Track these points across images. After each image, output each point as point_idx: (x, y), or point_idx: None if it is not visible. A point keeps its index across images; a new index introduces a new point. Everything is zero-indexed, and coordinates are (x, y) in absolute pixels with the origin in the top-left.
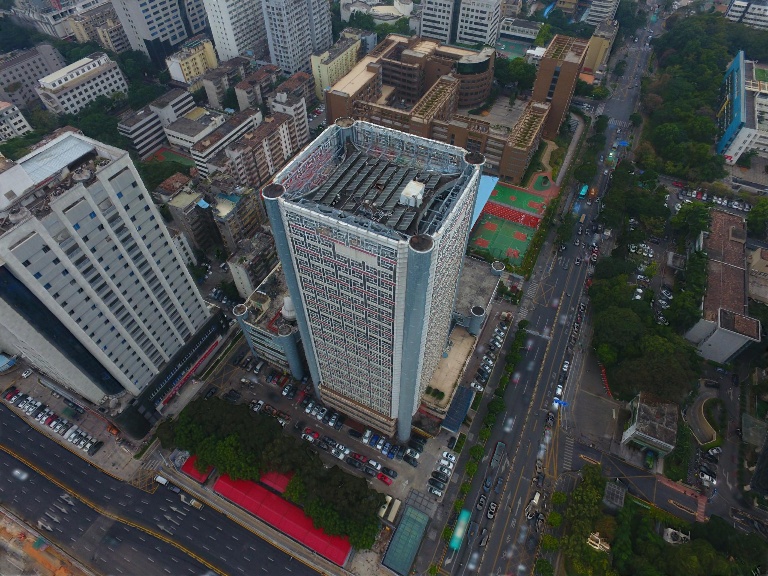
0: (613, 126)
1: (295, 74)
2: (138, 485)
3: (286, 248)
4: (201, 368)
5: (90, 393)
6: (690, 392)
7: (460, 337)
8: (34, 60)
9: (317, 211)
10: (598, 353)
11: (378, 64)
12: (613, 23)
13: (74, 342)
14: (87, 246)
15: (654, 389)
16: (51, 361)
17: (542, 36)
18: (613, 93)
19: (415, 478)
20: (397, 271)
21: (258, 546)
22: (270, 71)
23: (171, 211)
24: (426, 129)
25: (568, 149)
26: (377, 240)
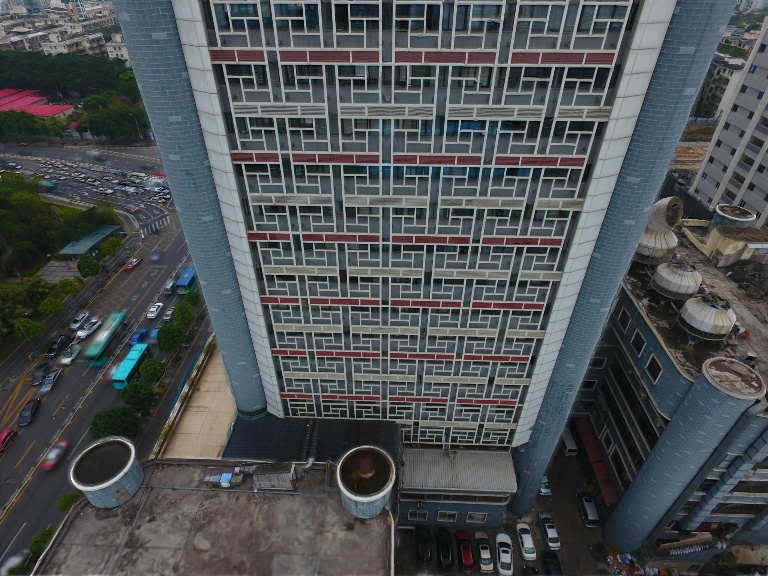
0: None
1: None
2: None
3: None
4: None
5: None
6: None
7: None
8: None
9: None
10: None
11: None
12: None
13: None
14: None
15: None
16: None
17: None
18: None
19: None
20: None
21: None
22: None
23: None
24: None
25: None
26: None
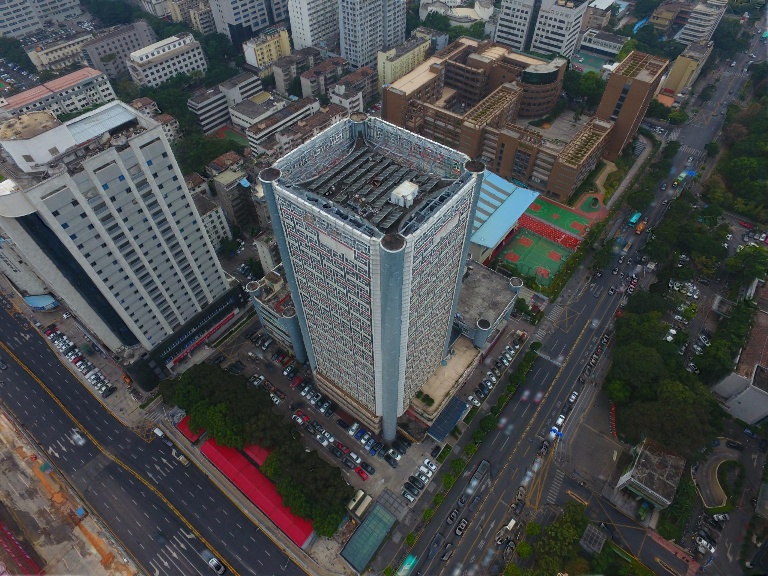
0: (685, 154)
1: (360, 68)
2: (138, 432)
3: (281, 231)
4: (216, 336)
5: (108, 340)
6: (704, 449)
7: (464, 348)
8: (130, 35)
9: (303, 198)
10: (609, 389)
11: (441, 65)
12: (707, 44)
13: (95, 291)
14: (114, 206)
15: (661, 438)
16: (75, 305)
17: (625, 51)
18: (693, 119)
19: (392, 479)
20: (371, 267)
21: (230, 511)
22: (337, 63)
23: (215, 186)
24: (477, 135)
25: (628, 172)
26: (352, 234)
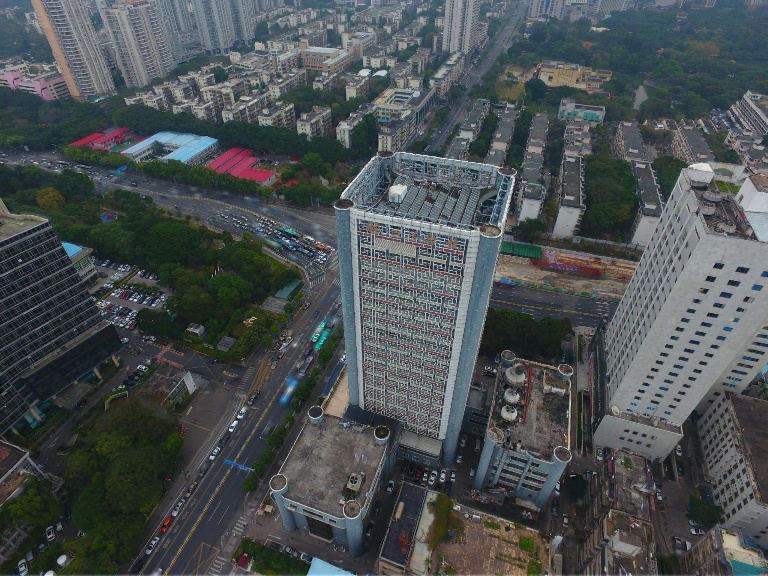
0: None
1: None
2: None
3: None
4: None
5: None
6: None
7: None
8: None
9: (465, 162)
10: (181, 440)
11: None
12: None
13: None
14: None
15: None
16: None
17: None
18: None
19: None
20: None
21: None
22: None
23: None
24: None
25: None
26: None
